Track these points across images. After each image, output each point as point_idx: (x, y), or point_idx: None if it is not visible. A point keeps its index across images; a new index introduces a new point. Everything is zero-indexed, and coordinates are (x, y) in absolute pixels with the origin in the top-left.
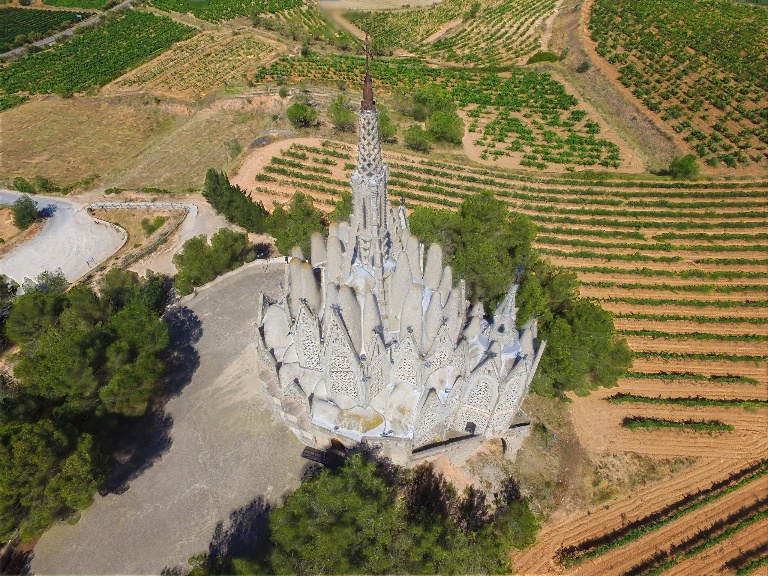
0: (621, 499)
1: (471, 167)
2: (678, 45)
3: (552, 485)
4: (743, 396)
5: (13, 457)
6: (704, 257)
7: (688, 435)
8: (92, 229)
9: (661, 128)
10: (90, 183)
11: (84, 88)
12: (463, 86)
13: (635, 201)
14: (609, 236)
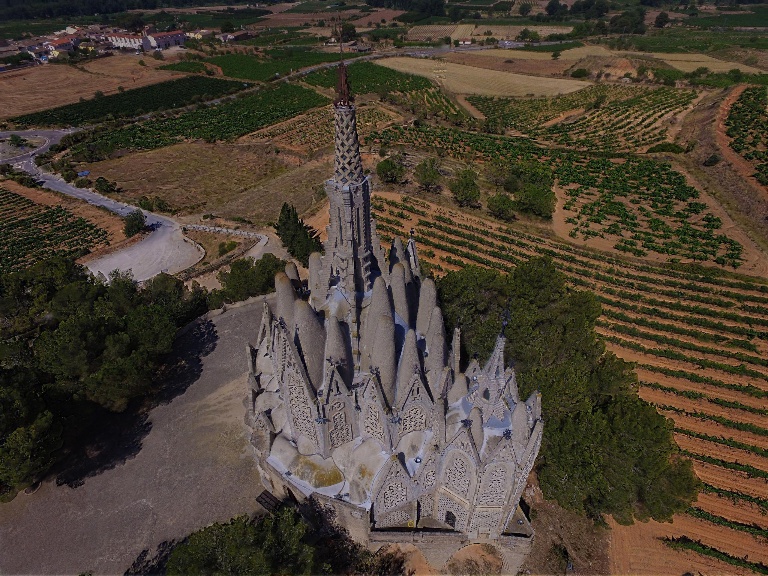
0: None
1: (553, 241)
2: None
3: None
4: None
5: None
6: None
7: None
8: (180, 245)
9: None
10: (195, 208)
11: (225, 137)
12: (568, 166)
13: (751, 306)
14: (708, 340)
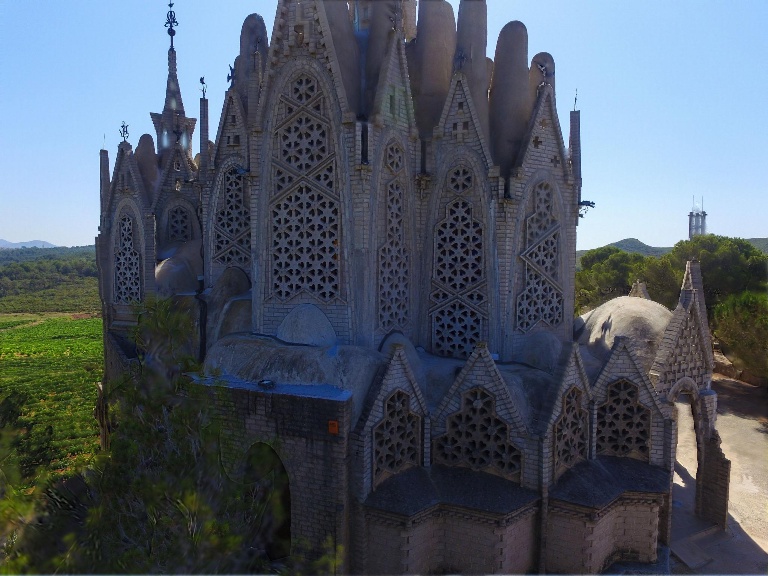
0: None
1: None
2: None
3: None
4: None
5: None
6: None
7: None
8: None
9: None
10: None
11: None
12: None
13: None
14: None
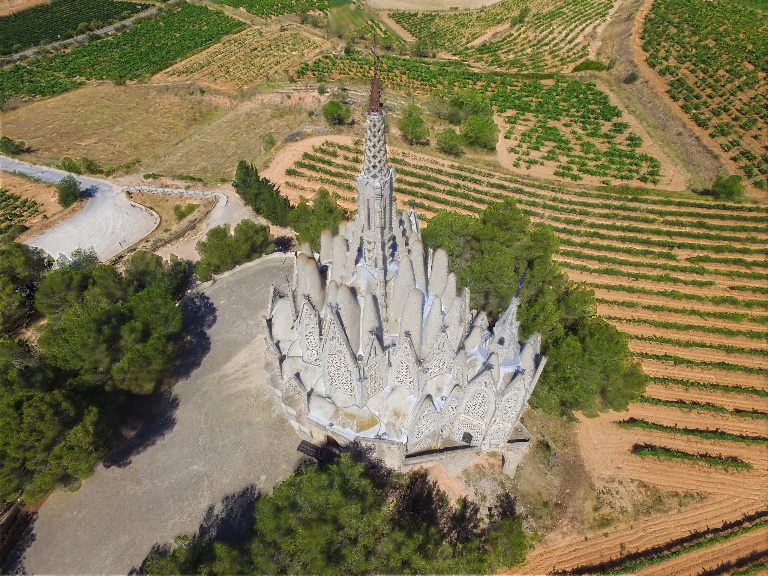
0: (622, 528)
1: (502, 174)
2: (736, 59)
3: (550, 505)
4: (767, 434)
5: (22, 422)
6: (740, 284)
7: (702, 469)
8: (128, 211)
9: (708, 145)
10: (131, 167)
11: (136, 76)
12: (503, 92)
13: (671, 220)
14: (639, 254)
